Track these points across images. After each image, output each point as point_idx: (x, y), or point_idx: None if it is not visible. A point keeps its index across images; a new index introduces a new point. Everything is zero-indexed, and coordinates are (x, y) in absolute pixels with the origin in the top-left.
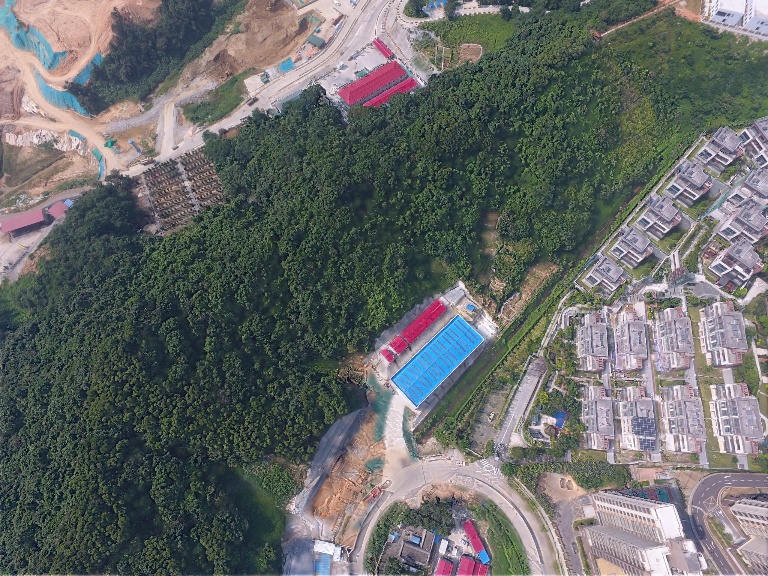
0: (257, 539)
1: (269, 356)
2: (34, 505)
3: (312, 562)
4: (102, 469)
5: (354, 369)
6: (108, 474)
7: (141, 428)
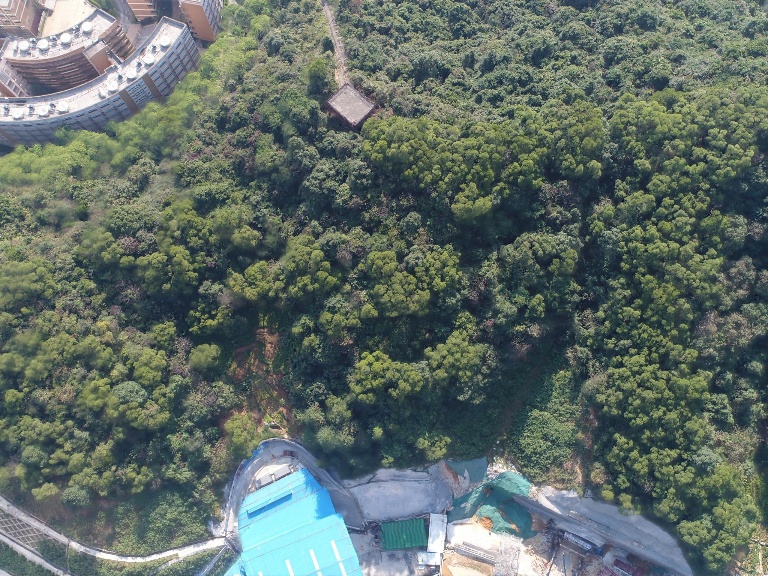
0: (451, 418)
1: (765, 380)
2: (470, 63)
3: (412, 513)
4: (555, 149)
5: (767, 554)
6: (546, 160)
7: (625, 192)
